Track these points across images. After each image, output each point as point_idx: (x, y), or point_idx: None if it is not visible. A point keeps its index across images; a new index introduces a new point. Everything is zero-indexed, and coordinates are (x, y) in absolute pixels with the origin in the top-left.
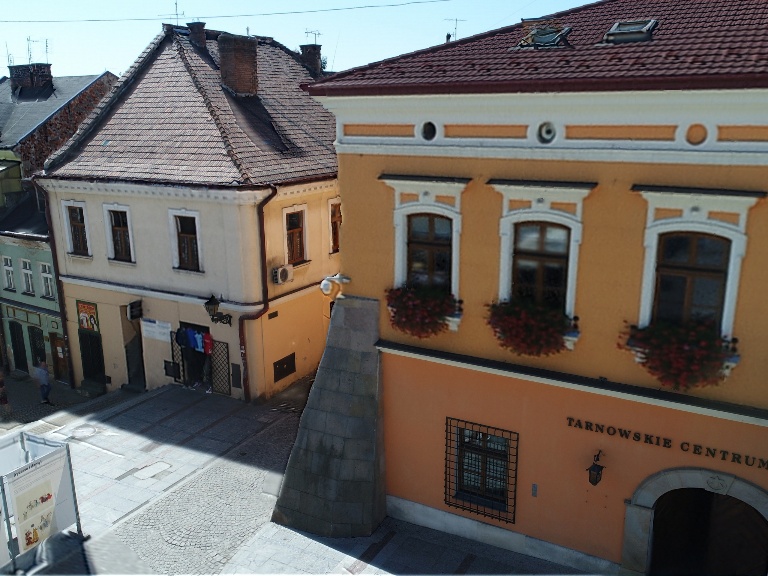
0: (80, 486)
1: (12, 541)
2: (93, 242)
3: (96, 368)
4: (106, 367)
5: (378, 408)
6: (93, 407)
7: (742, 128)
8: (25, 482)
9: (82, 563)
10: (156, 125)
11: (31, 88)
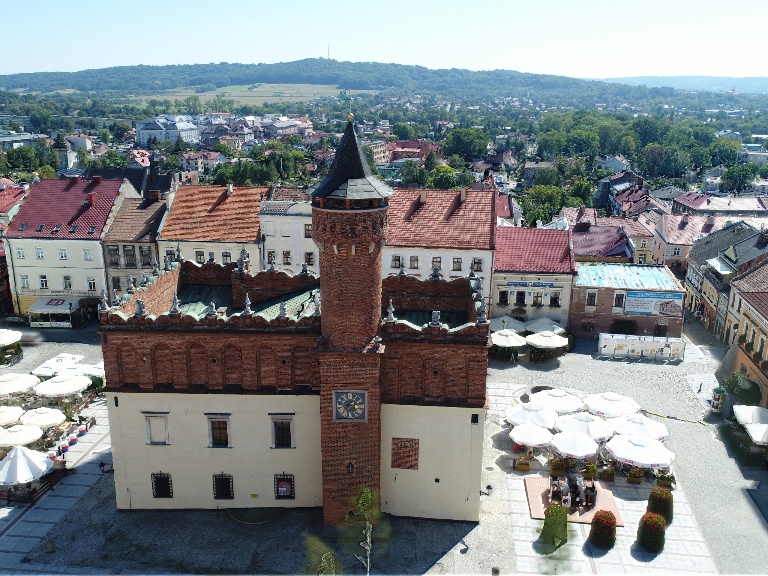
0: (692, 356)
1: (670, 354)
2: (735, 304)
3: (727, 340)
4: (729, 340)
5: (735, 357)
6: (717, 348)
7: (767, 324)
8: (676, 345)
9: (679, 363)
10: (764, 276)
11: (762, 242)
